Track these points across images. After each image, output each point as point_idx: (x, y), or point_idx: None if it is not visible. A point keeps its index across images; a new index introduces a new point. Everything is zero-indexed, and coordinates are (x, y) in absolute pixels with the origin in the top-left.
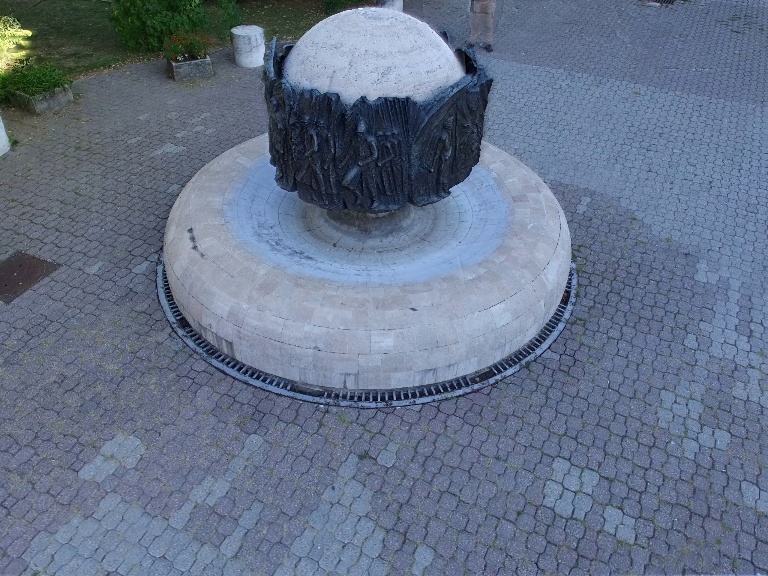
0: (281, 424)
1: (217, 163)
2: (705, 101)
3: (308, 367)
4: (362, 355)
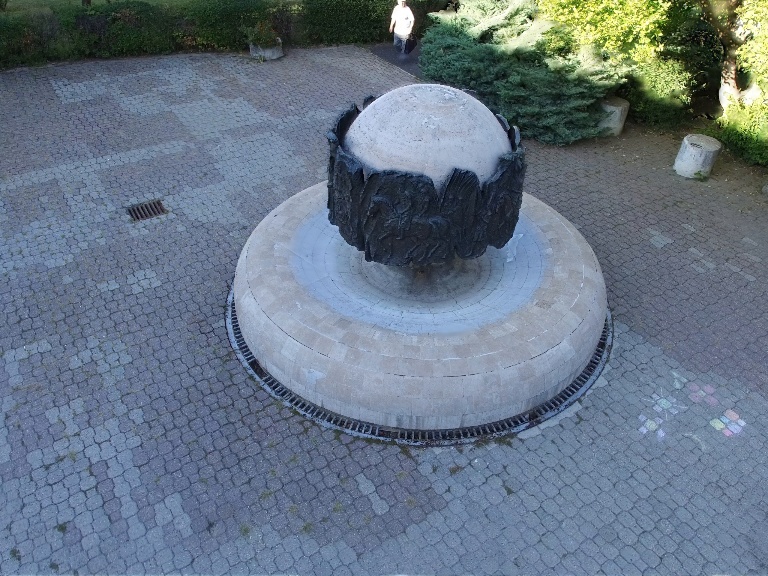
0: None
1: (523, 194)
2: None
3: None
4: None
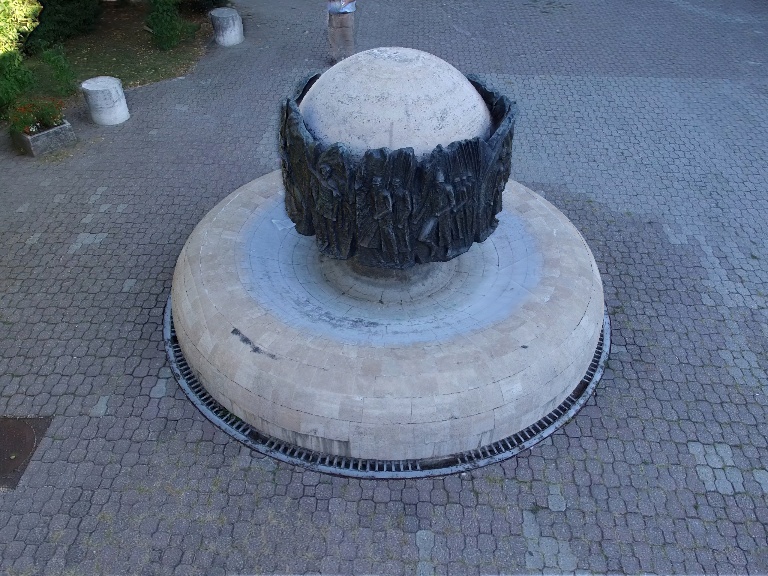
0: (439, 509)
1: (203, 245)
2: (568, 80)
3: (444, 440)
4: (497, 409)
